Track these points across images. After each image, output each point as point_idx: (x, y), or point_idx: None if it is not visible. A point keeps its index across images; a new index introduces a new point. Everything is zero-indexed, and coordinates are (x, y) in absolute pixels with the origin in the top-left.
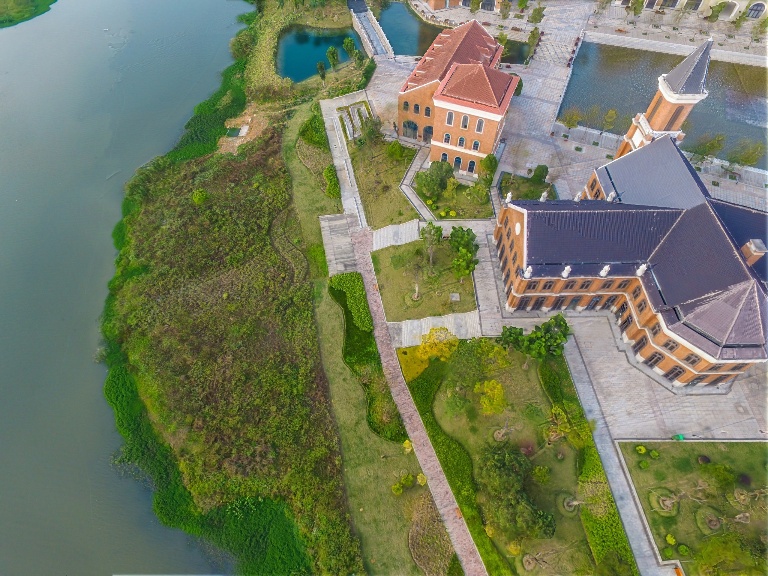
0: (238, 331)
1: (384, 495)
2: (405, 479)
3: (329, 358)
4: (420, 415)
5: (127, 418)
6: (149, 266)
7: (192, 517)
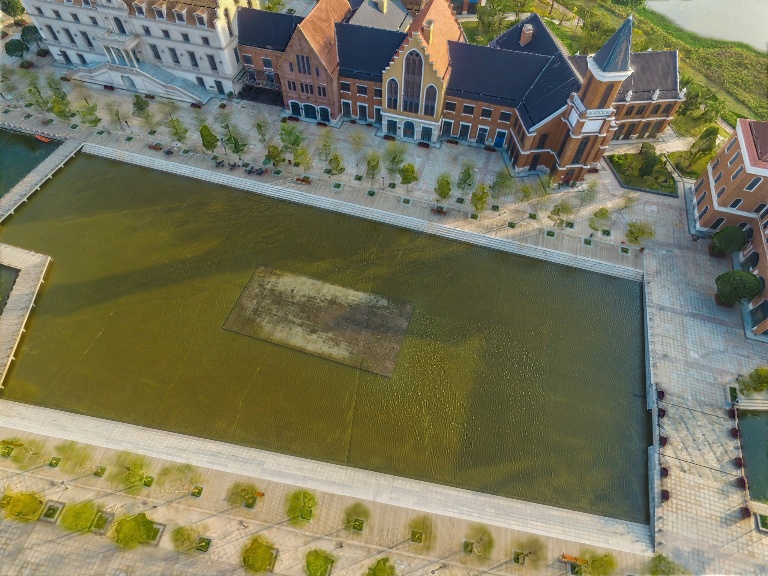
0: None
1: None
2: None
3: (718, 89)
4: None
5: None
6: None
7: (730, 43)
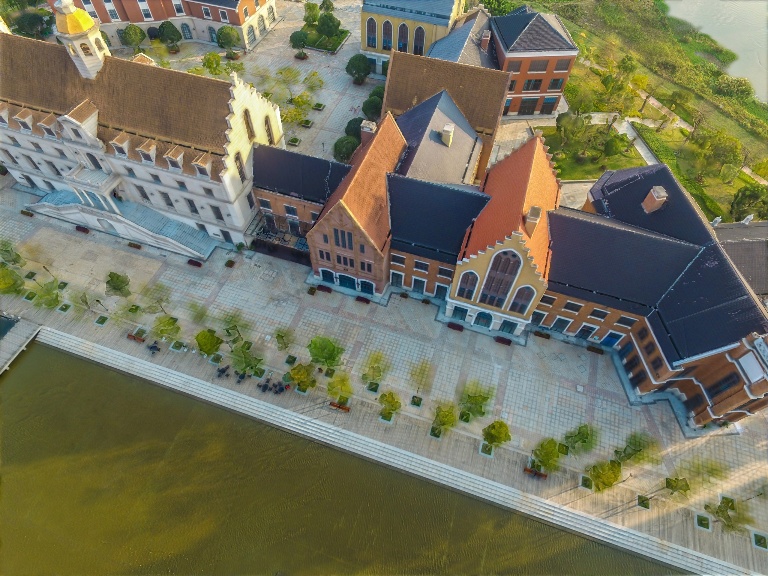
0: None
1: None
2: None
3: None
4: None
5: None
6: None
7: None
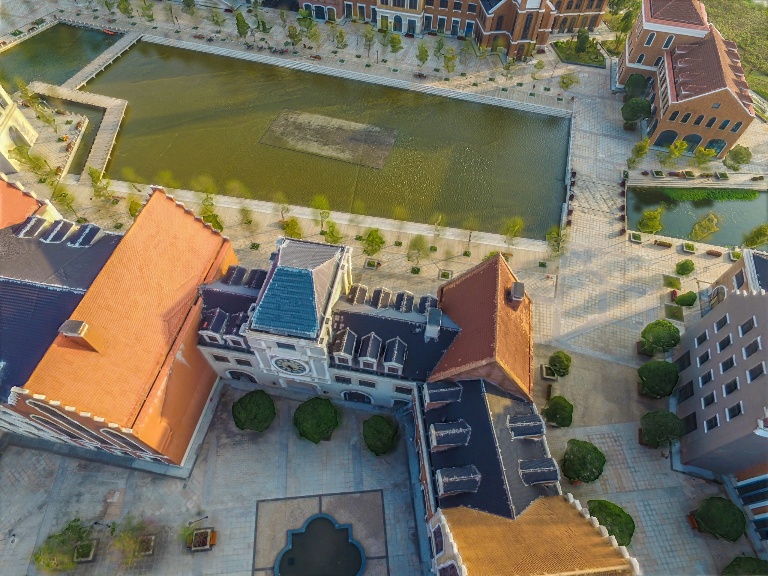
0: (707, 8)
1: None
2: None
3: None
4: None
5: None
6: None
7: None
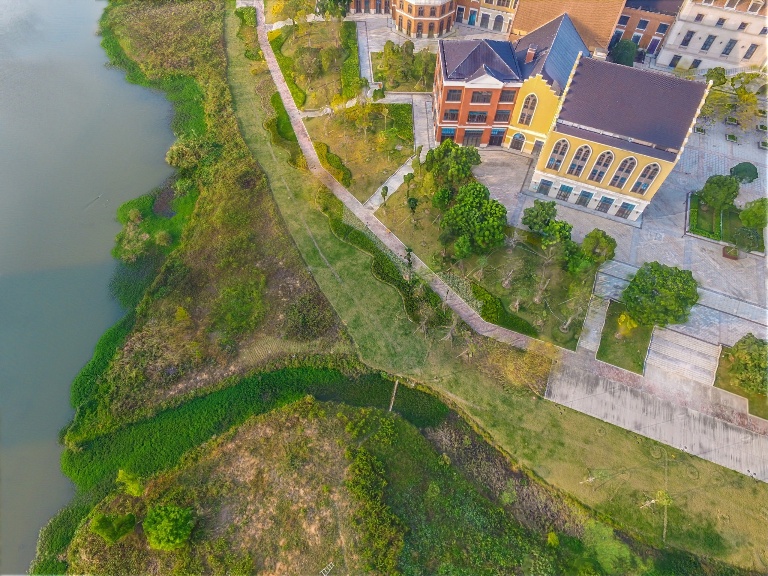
0: None
1: (247, 76)
2: (258, 68)
3: (229, 35)
4: (273, 52)
5: (113, 52)
6: (129, 1)
7: (145, 80)
